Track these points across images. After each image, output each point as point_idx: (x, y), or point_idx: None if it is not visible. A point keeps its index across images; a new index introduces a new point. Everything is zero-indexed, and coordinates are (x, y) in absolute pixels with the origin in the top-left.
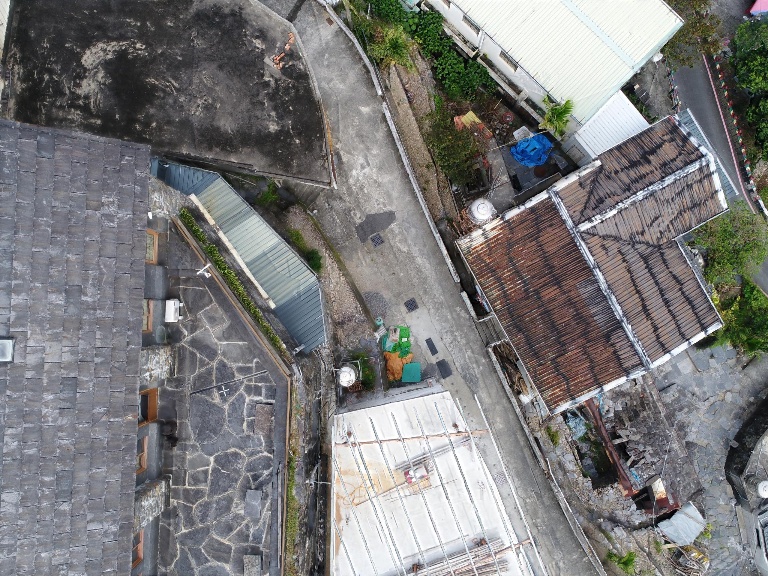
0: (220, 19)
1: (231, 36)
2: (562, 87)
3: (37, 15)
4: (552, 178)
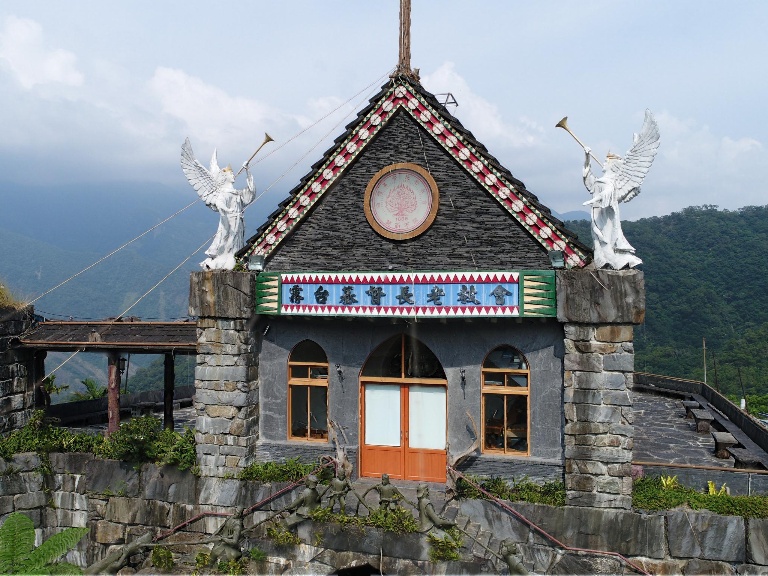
0: None
1: None
2: None
3: None
4: None
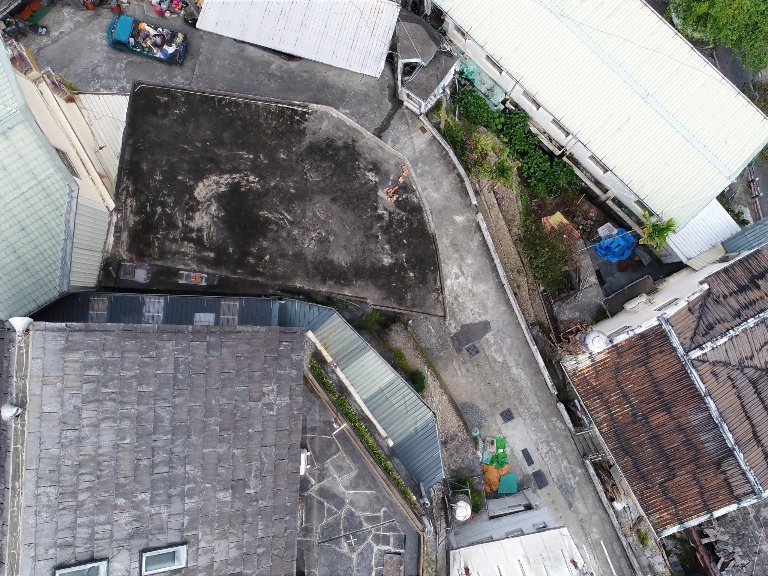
0: (333, 152)
1: (344, 169)
2: (657, 195)
3: (149, 148)
4: (642, 281)
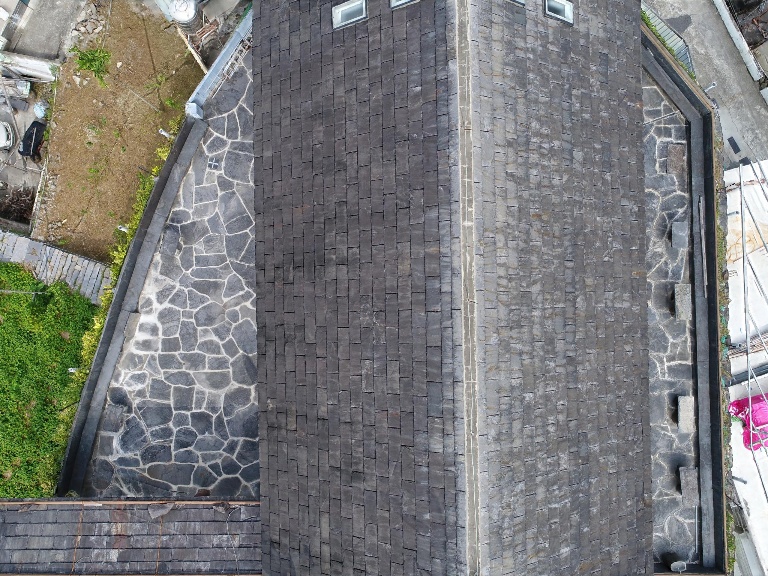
0: None
1: None
2: None
3: None
4: None
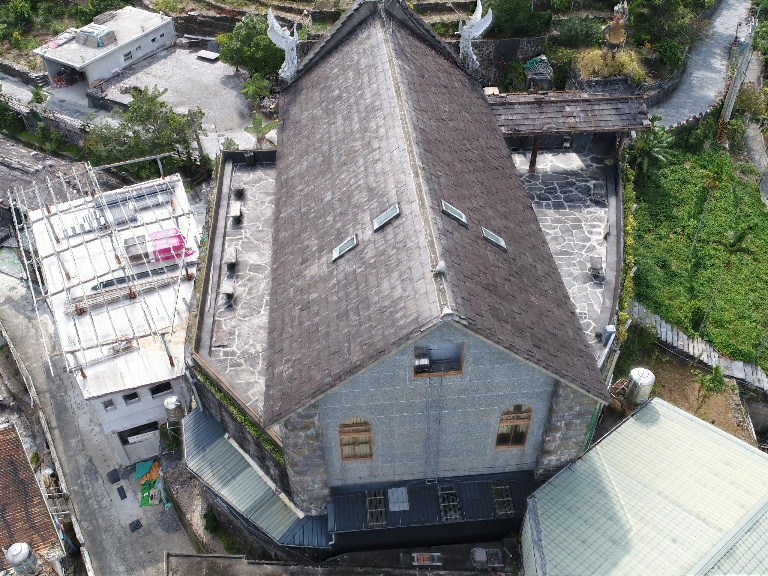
0: None
1: None
2: None
3: None
4: None
